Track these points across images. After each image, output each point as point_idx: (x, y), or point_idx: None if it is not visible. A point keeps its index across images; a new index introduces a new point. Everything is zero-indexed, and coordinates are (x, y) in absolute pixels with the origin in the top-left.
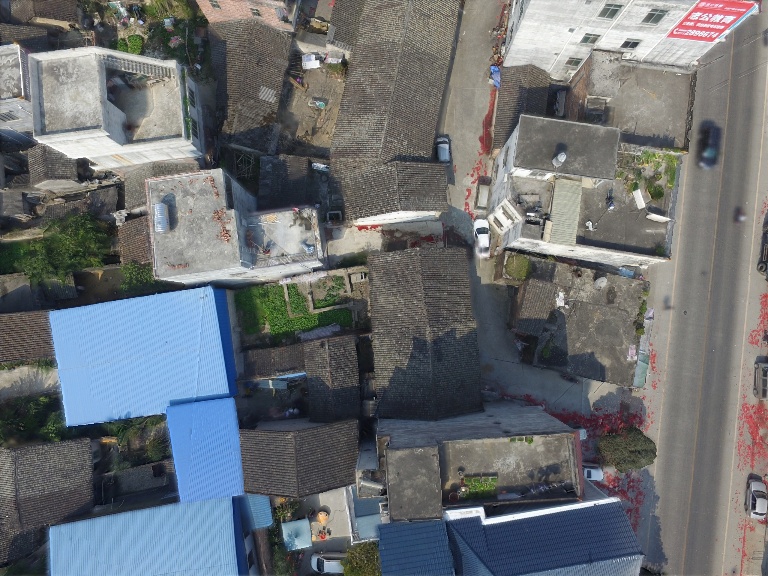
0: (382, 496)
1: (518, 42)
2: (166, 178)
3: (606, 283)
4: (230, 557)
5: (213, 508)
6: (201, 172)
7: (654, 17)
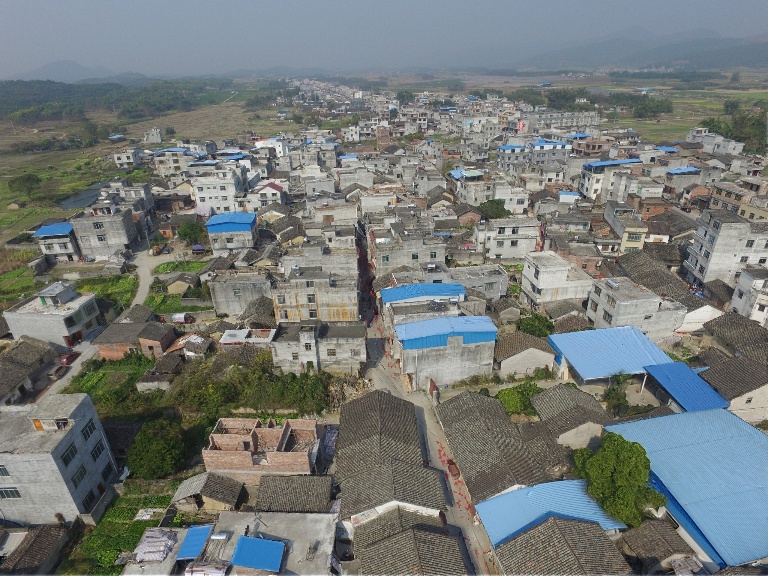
0: None
1: (711, 266)
2: (602, 279)
3: None
4: (754, 430)
5: (714, 412)
6: None
7: None
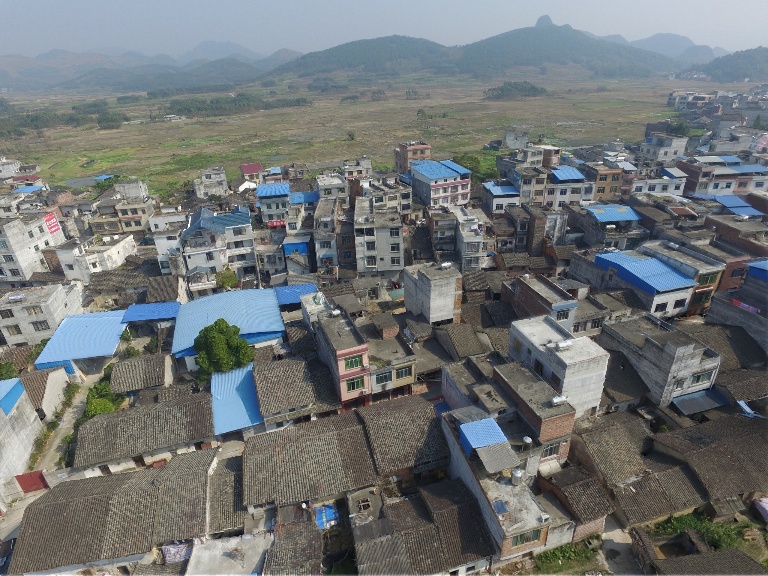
0: (180, 253)
1: None
2: None
3: (138, 253)
4: None
5: None
6: (4, 296)
7: (41, 230)
